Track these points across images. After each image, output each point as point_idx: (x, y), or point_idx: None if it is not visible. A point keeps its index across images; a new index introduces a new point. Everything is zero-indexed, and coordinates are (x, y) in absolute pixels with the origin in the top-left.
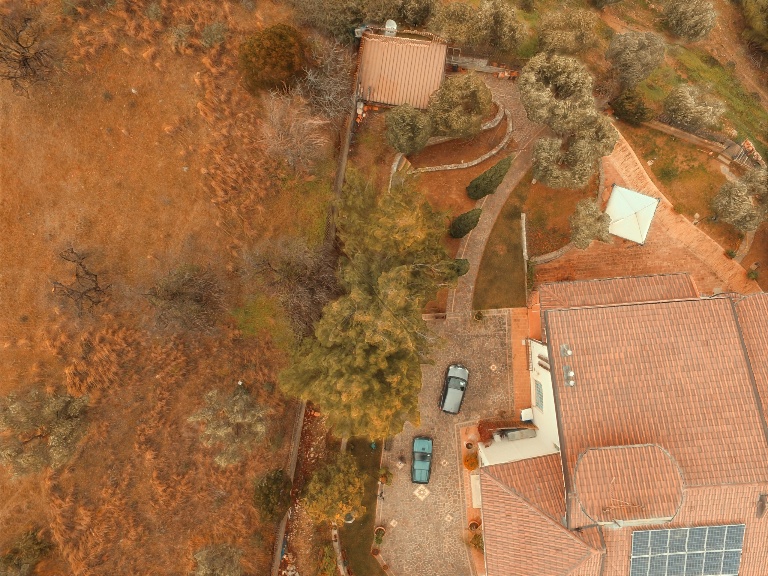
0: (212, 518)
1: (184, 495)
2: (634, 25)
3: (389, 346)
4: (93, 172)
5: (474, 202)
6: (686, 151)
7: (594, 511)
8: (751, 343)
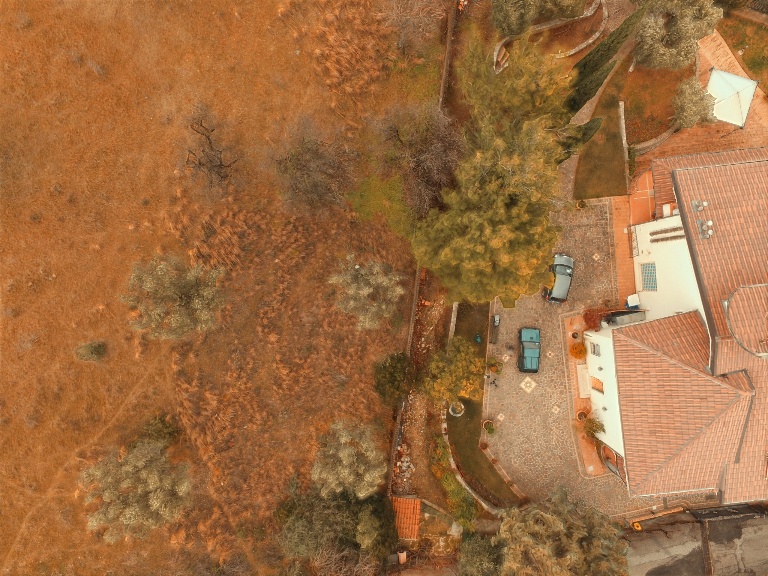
0: (332, 404)
1: (306, 379)
2: None
3: (536, 192)
4: (207, 56)
5: None
6: None
7: (751, 344)
8: None
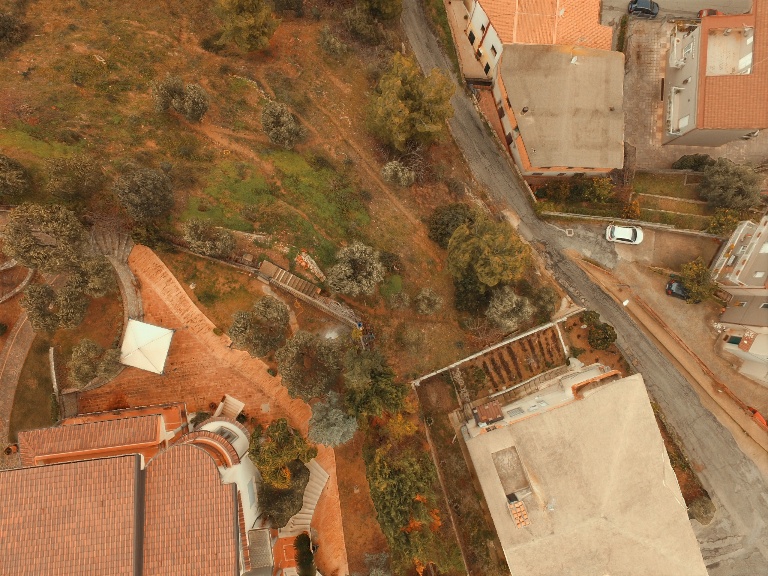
0: None
1: None
2: (241, 131)
3: None
4: None
5: (5, 338)
6: (227, 273)
7: None
8: (157, 498)
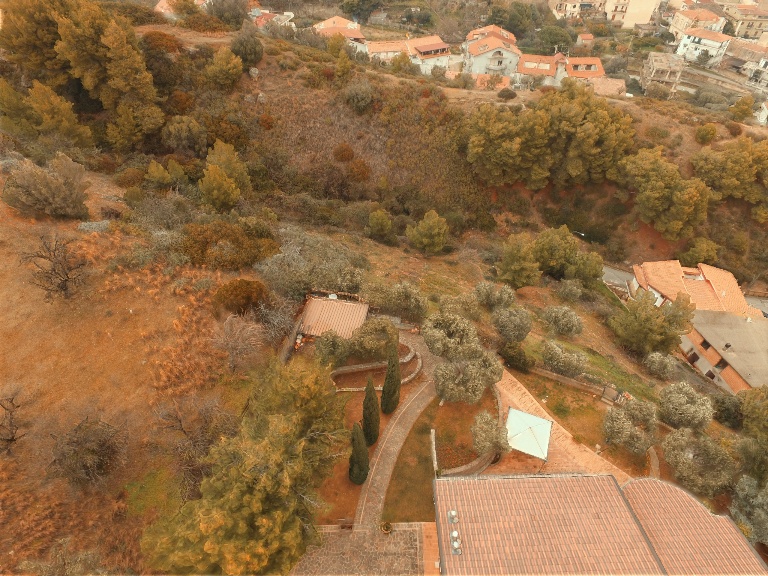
0: None
1: None
2: None
3: (265, 478)
4: (68, 359)
5: (389, 418)
6: (573, 393)
7: None
8: (648, 523)
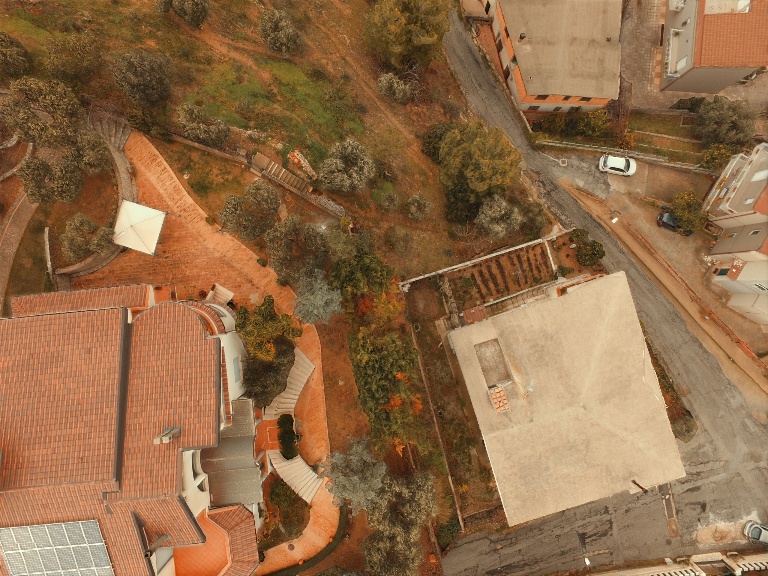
0: None
1: None
2: (240, 41)
3: None
4: None
5: (2, 218)
6: (220, 165)
7: None
8: (142, 350)
